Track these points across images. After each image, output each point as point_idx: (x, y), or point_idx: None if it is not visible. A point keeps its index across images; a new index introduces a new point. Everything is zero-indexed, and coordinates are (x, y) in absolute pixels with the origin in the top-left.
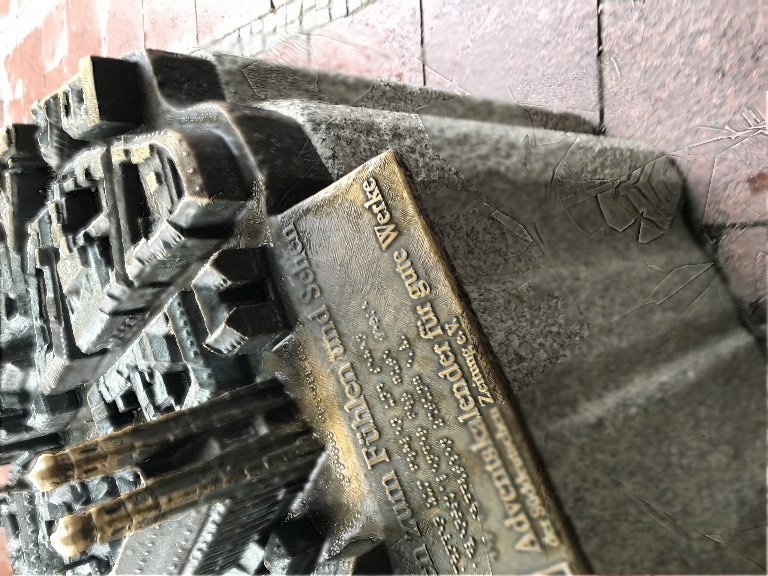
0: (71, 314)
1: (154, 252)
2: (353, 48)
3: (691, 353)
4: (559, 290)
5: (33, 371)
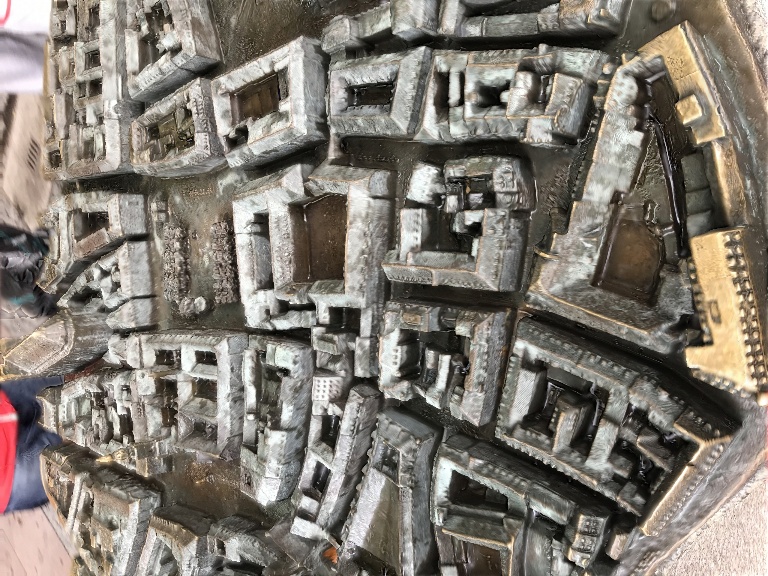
0: (122, 522)
1: (62, 463)
2: (31, 433)
3: (3, 306)
4: (18, 332)
5: (207, 575)
